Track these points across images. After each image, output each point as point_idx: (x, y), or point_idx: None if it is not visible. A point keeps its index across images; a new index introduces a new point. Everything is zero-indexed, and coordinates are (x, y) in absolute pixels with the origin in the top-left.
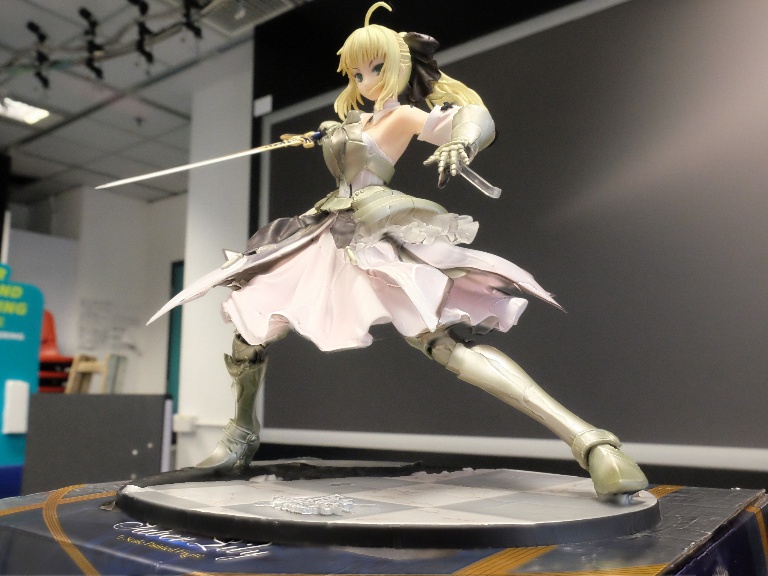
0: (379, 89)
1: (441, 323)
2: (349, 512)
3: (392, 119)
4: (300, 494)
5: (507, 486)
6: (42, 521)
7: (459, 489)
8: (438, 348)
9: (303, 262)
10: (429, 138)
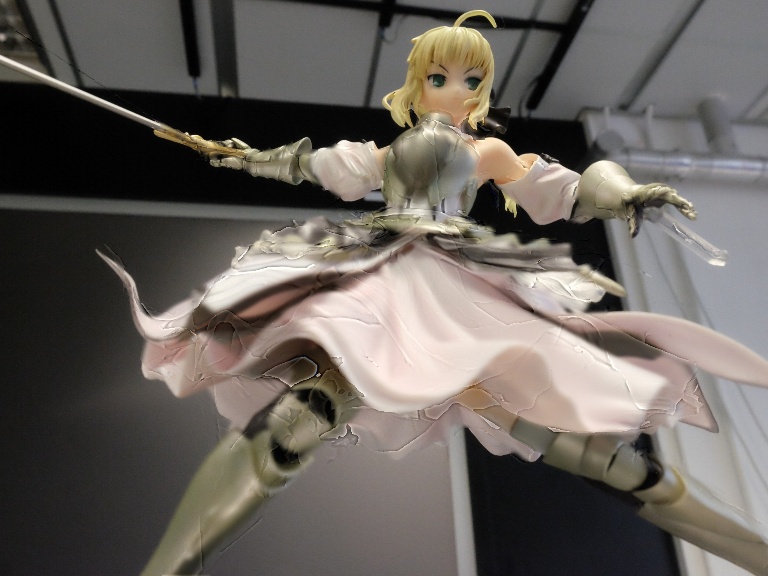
0: (471, 105)
1: None
2: None
3: (488, 146)
4: None
5: None
6: None
7: None
8: None
9: (402, 280)
10: (520, 189)
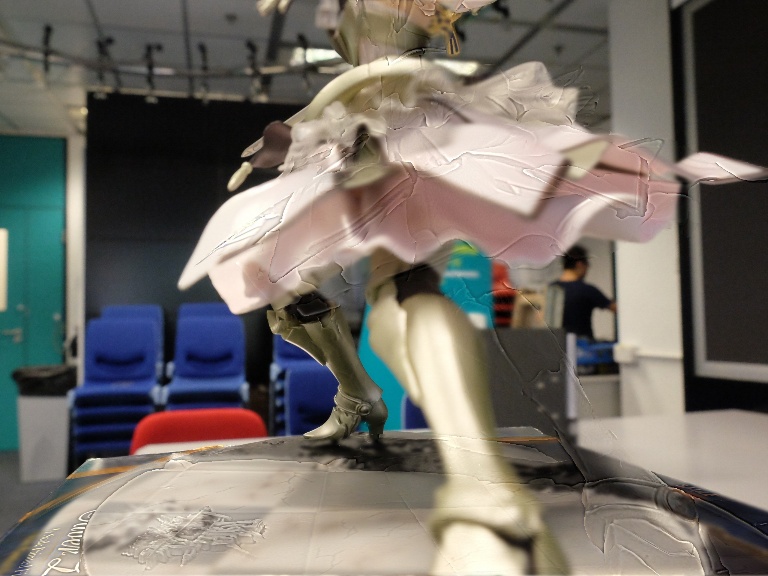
0: None
1: (401, 258)
2: (181, 562)
3: None
4: (286, 502)
5: (585, 541)
6: (75, 492)
7: (493, 533)
8: (450, 297)
9: None
10: None
